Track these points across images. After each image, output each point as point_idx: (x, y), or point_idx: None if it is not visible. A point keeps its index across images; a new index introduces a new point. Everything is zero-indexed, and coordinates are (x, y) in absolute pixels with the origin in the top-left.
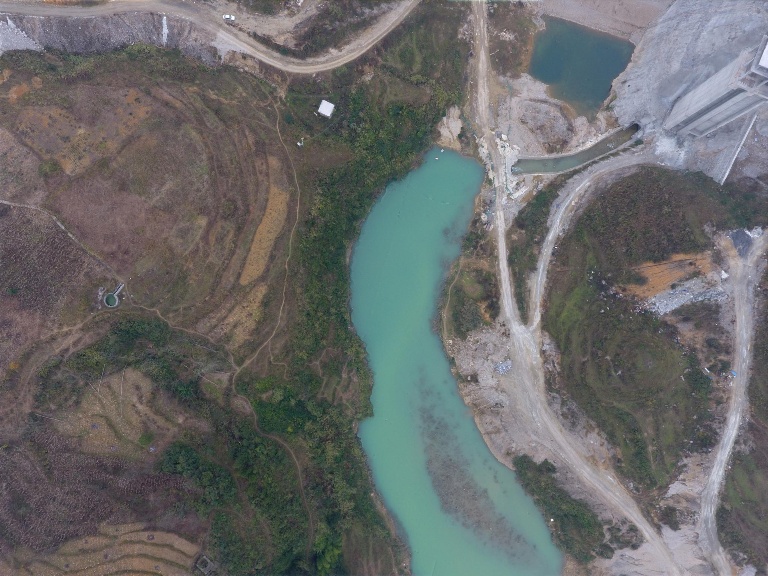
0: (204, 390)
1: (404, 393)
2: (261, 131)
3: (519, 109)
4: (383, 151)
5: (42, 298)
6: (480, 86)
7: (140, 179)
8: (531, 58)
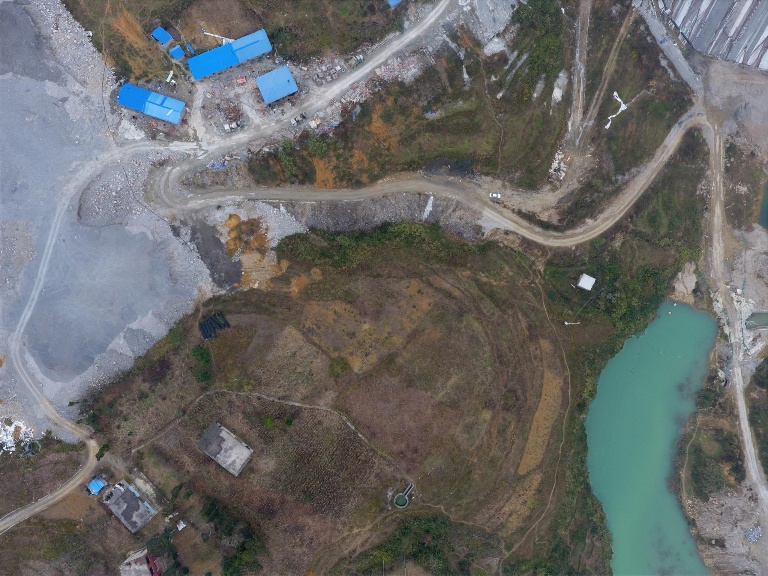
0: (474, 575)
1: (642, 554)
2: (531, 313)
3: (755, 263)
4: (635, 319)
5: (335, 502)
6: (715, 240)
7: (426, 374)
8: (761, 207)
